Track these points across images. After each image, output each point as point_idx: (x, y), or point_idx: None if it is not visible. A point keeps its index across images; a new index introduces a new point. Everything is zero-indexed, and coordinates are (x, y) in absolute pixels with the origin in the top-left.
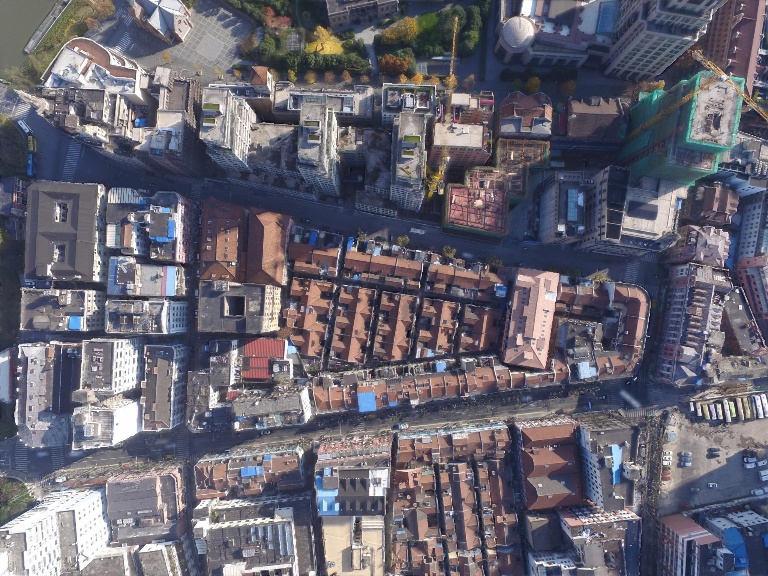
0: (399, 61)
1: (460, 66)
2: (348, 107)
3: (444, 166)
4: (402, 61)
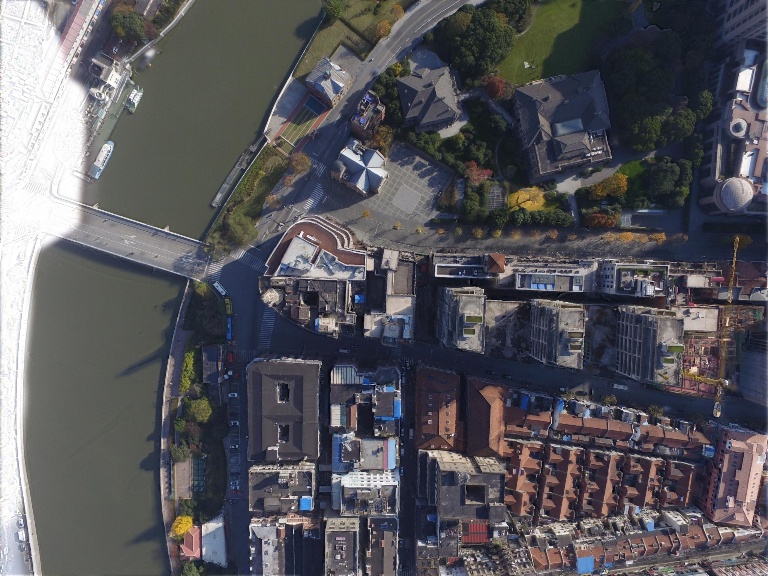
0: (610, 220)
1: (663, 217)
2: (577, 286)
3: (720, 388)
4: (613, 220)
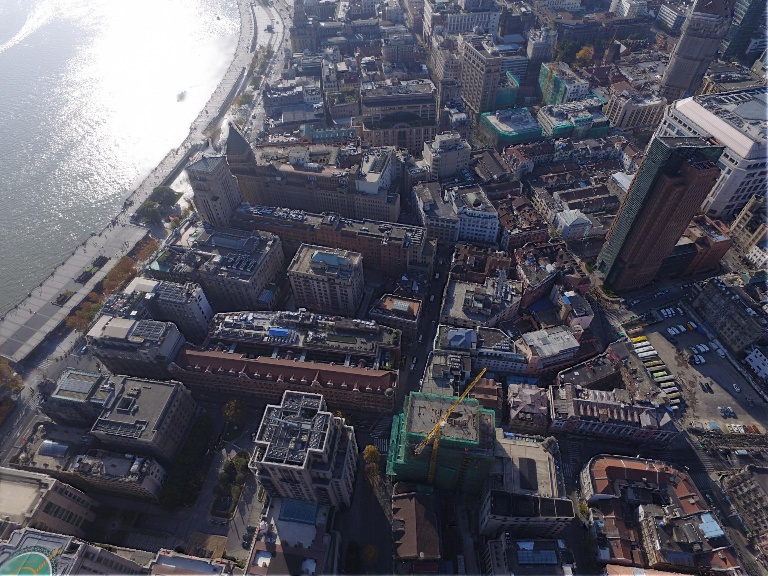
0: None
1: None
2: None
3: None
4: None
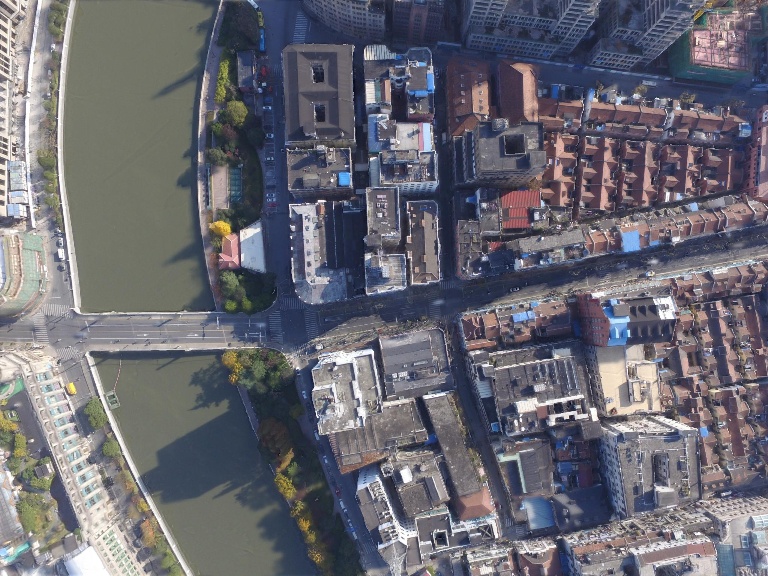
0: None
1: None
2: None
3: None
4: None
